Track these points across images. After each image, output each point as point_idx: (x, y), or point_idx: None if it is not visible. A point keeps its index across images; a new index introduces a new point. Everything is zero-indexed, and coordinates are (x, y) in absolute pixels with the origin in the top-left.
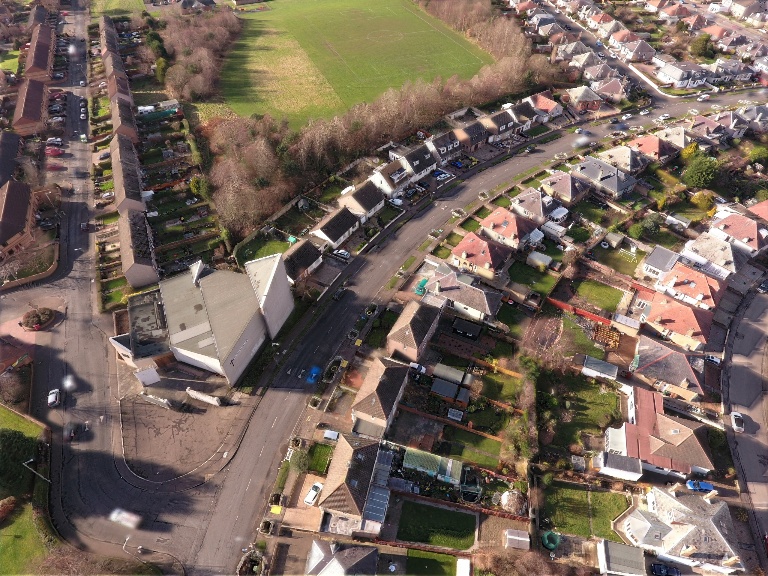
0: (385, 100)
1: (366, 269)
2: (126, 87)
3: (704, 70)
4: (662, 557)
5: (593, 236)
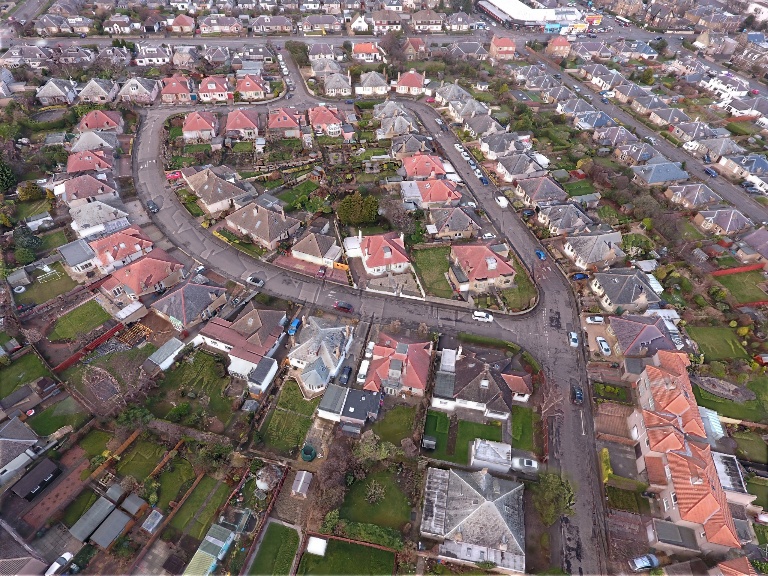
0: None
1: None
2: None
3: None
4: (336, 373)
5: None
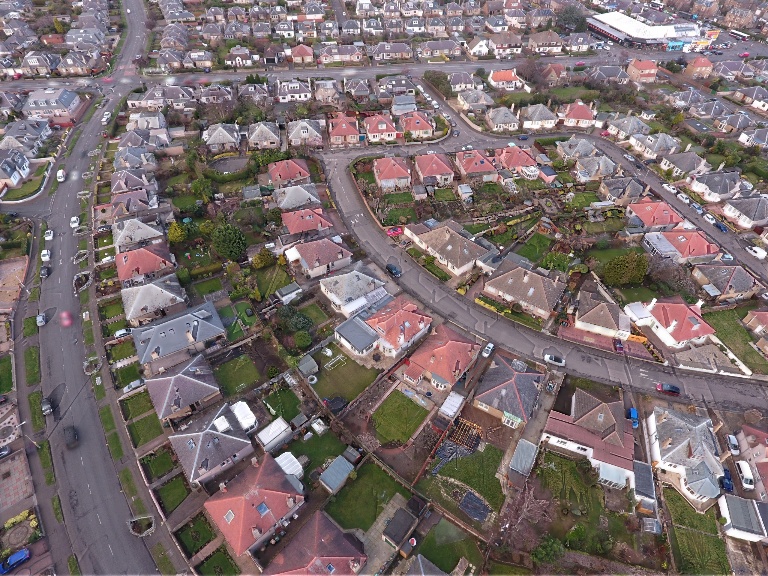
0: None
1: None
2: None
3: (14, 151)
4: None
5: (292, 387)
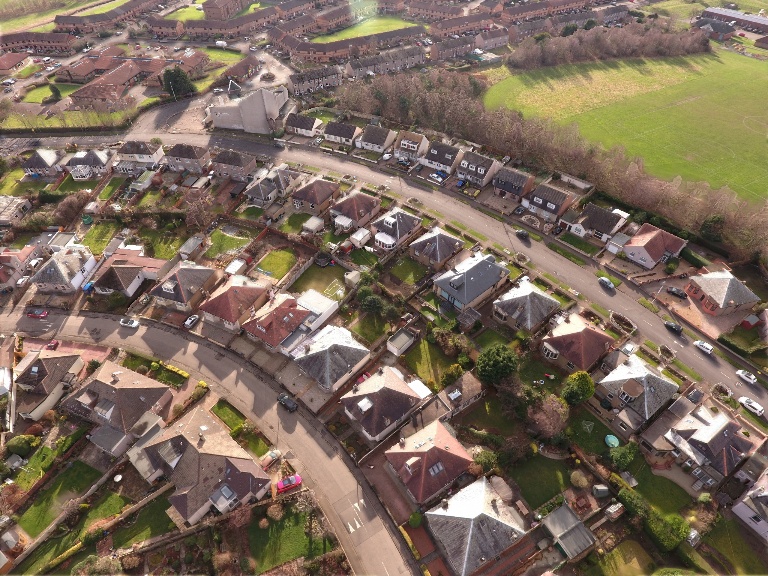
0: (533, 121)
1: (305, 153)
2: (495, 36)
3: None
4: None
5: None
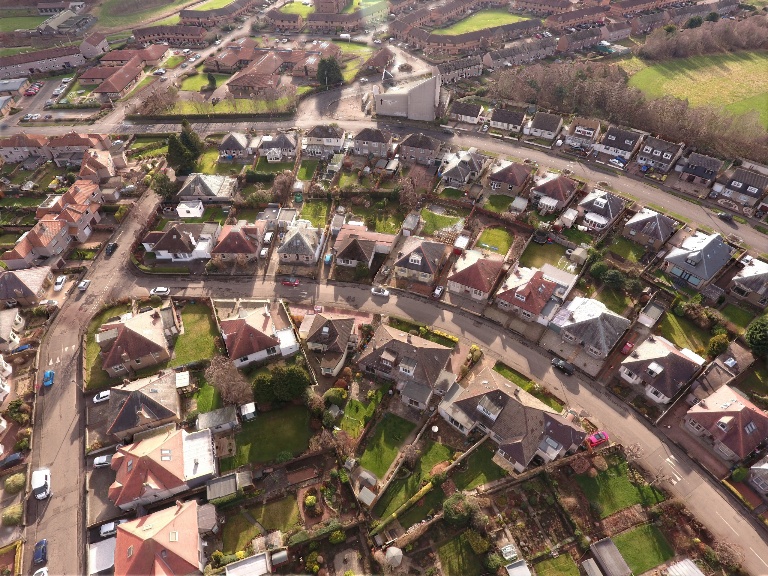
0: (704, 109)
1: (476, 139)
2: (620, 28)
3: None
4: None
5: None
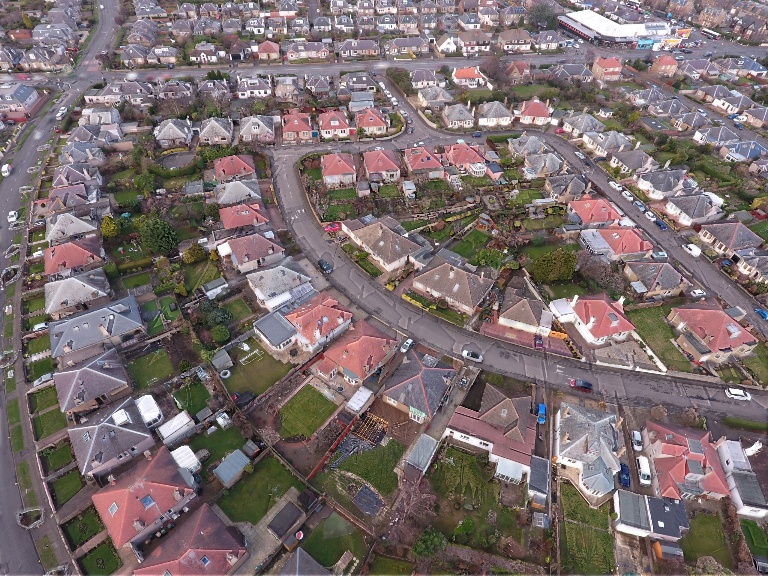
0: None
1: None
2: None
3: None
4: None
5: (204, 381)
